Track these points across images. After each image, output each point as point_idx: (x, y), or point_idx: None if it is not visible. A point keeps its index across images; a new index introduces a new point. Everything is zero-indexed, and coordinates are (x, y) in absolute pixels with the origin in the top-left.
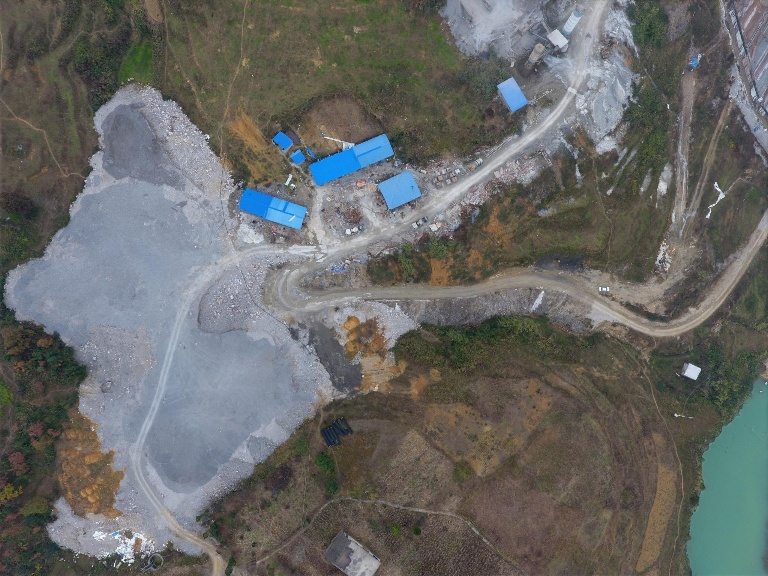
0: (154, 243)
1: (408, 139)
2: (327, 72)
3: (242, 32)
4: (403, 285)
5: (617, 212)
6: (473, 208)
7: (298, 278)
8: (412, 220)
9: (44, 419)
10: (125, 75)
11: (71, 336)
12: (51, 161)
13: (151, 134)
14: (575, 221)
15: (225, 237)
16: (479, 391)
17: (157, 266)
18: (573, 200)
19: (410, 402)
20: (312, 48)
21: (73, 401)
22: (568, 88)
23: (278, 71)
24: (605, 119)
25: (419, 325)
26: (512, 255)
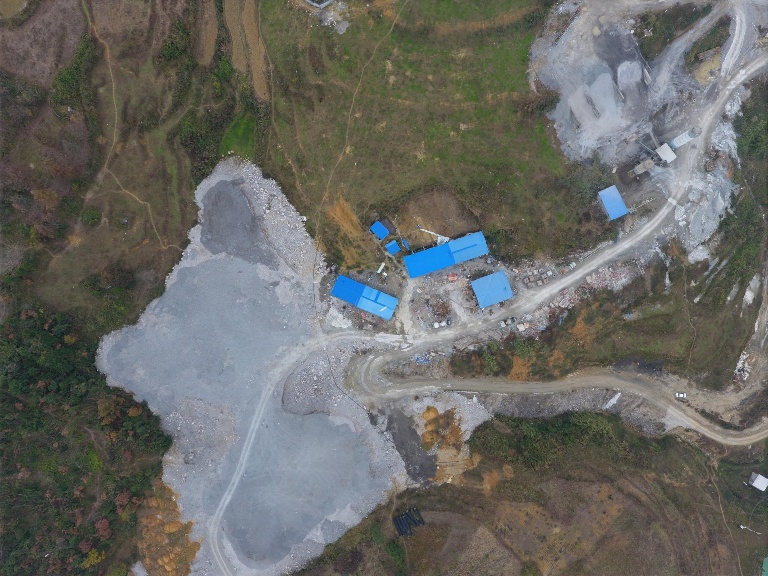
0: (245, 320)
1: (503, 237)
2: (429, 165)
3: (349, 120)
4: (482, 377)
5: (702, 320)
6: (562, 311)
7: (382, 365)
8: (500, 318)
9: (130, 488)
10: (226, 147)
11: (159, 406)
12: (152, 233)
13: (250, 212)
14: (659, 327)
15: (314, 320)
16: (551, 491)
17: (246, 343)
18: (659, 306)
19: (482, 497)
20: (417, 141)
21: (158, 471)
22: (668, 198)
23: (381, 161)
24: (701, 230)
25: (493, 416)
26: (593, 355)
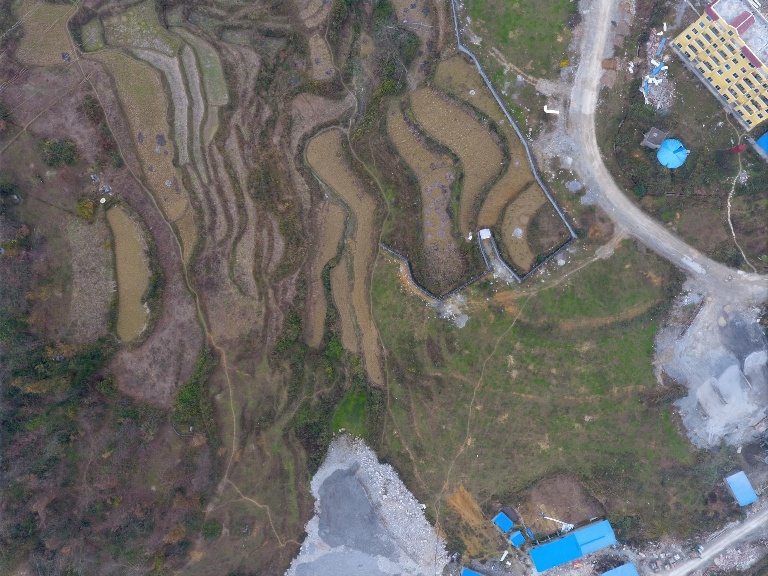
0: None
1: (628, 522)
2: (552, 455)
3: (470, 412)
4: None
5: None
6: None
7: None
8: None
9: None
10: (336, 425)
11: None
12: (271, 534)
13: (368, 504)
14: None
15: None
16: None
17: None
18: None
19: None
20: (540, 433)
21: None
22: None
23: (503, 452)
24: None
25: None
26: None
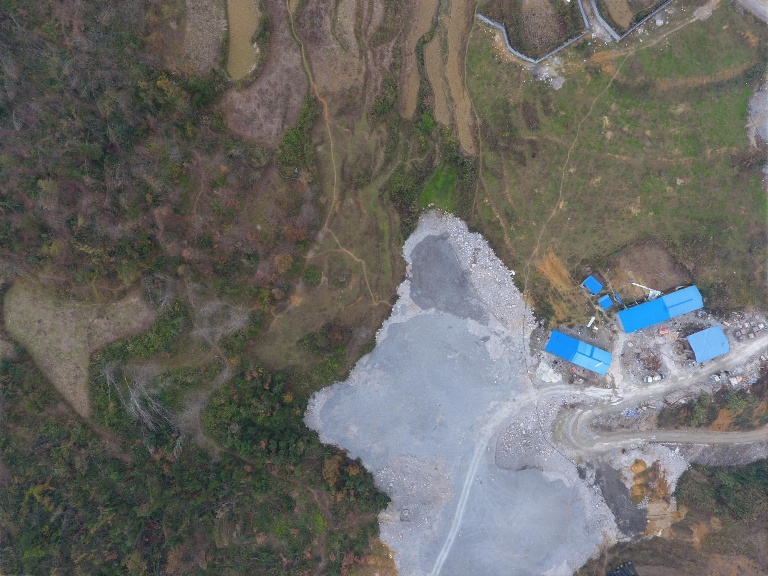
0: (456, 376)
1: (714, 290)
2: (643, 220)
3: (563, 175)
4: (685, 429)
5: None
6: None
7: (590, 418)
8: (711, 371)
9: (354, 548)
10: (425, 200)
11: (373, 463)
12: (366, 290)
13: (460, 267)
14: None
15: (525, 374)
16: (760, 544)
17: (458, 399)
18: None
19: (694, 551)
20: (632, 196)
21: (377, 530)
22: None
23: (594, 216)
24: None
25: (690, 465)
26: None
